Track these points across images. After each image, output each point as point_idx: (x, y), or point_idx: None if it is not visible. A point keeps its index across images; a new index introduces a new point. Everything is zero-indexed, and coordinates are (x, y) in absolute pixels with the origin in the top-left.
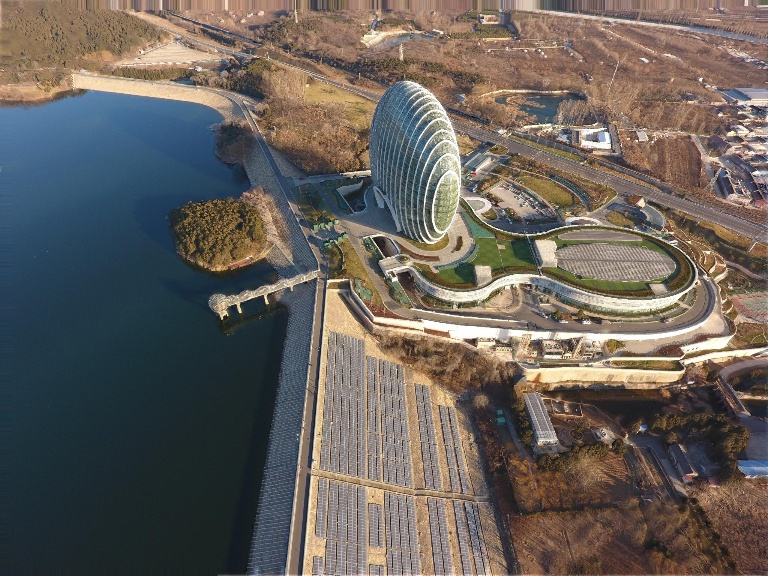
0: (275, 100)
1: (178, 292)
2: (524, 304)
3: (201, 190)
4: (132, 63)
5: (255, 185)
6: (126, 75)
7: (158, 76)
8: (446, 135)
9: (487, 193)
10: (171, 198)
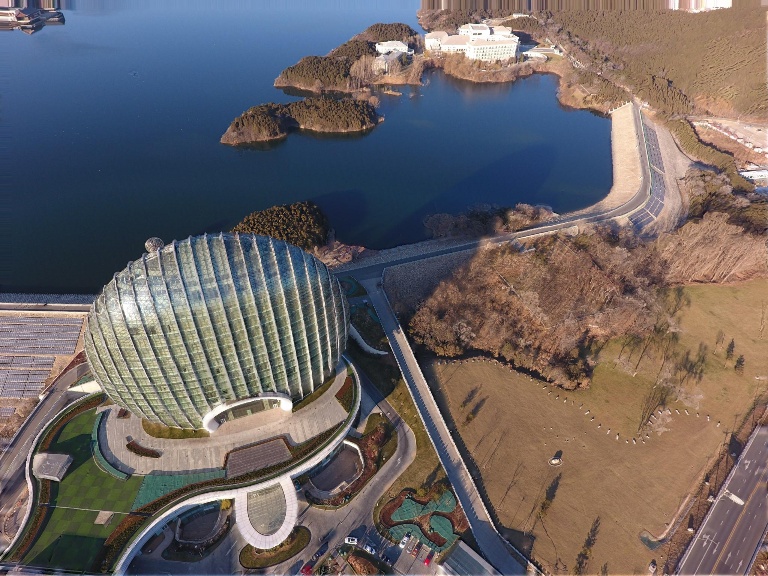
0: (623, 239)
1: (206, 231)
2: (5, 546)
3: (374, 219)
4: (724, 127)
5: (380, 253)
6: (679, 131)
7: (693, 149)
8: (101, 301)
9: (337, 568)
10: (361, 205)
